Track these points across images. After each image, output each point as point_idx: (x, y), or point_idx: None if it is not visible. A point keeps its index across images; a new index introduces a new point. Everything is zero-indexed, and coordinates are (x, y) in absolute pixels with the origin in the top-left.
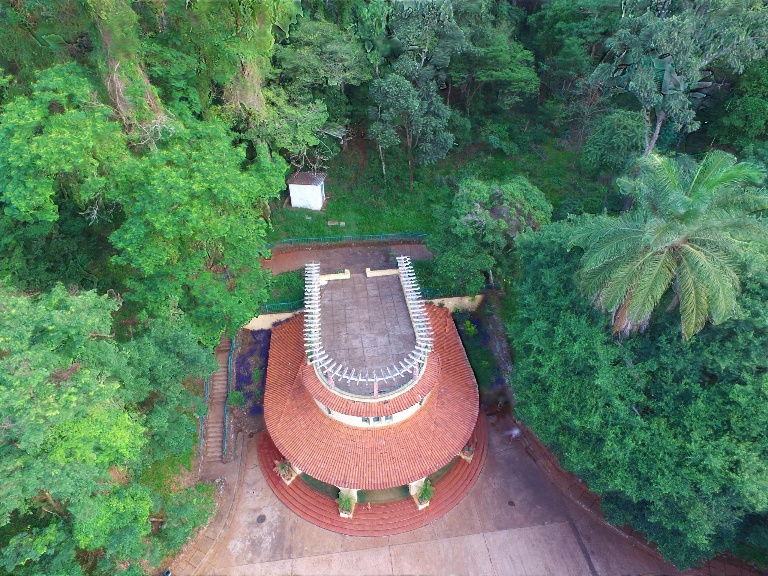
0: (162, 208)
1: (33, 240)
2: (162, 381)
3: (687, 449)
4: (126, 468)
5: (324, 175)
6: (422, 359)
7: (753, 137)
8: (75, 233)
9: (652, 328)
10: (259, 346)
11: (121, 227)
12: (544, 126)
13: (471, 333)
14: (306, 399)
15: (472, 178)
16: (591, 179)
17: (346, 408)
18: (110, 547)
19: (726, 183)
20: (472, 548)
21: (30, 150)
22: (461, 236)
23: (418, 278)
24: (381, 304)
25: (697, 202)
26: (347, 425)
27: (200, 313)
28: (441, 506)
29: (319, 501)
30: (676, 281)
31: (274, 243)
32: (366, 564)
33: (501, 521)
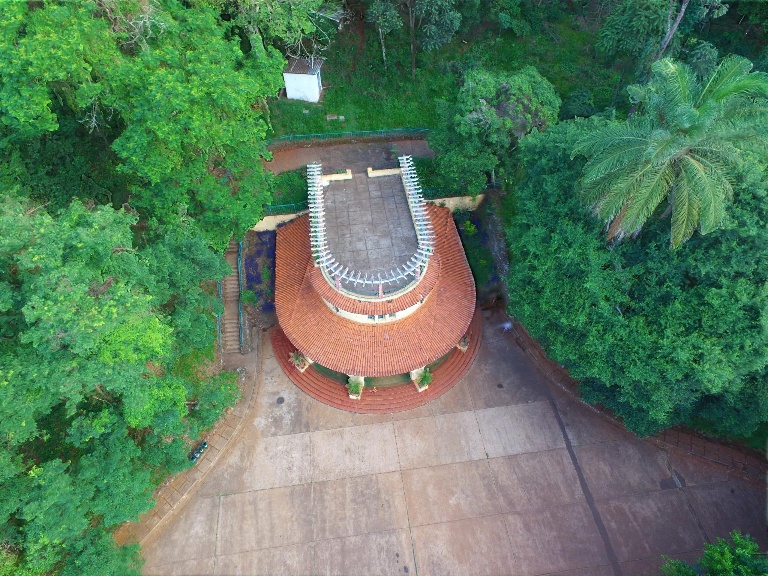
0: (162, 115)
1: (27, 142)
2: (180, 285)
3: (659, 344)
4: (159, 362)
5: (320, 62)
6: (424, 261)
7: None
8: (68, 133)
9: (644, 234)
10: (265, 247)
11: (122, 135)
12: None
13: (471, 233)
14: (315, 298)
15: (478, 64)
16: (605, 65)
17: (353, 307)
18: (156, 426)
19: (737, 93)
20: (464, 422)
21: (19, 55)
22: (465, 135)
23: (420, 177)
24: (383, 206)
25: (703, 117)
26: (354, 322)
27: (208, 218)
28: (438, 389)
29: (331, 386)
30: (672, 192)
31: (272, 140)
32: (373, 435)
33: (490, 400)
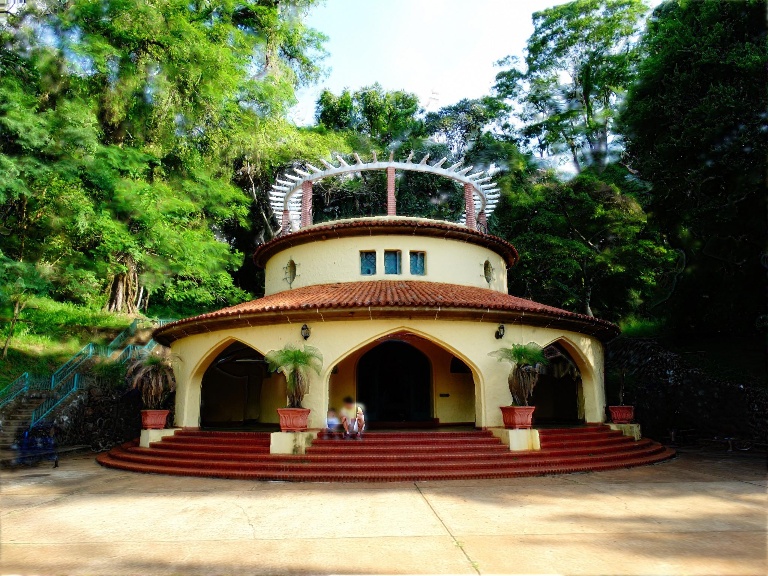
0: None
1: None
2: (0, 163)
3: None
4: None
5: None
6: None
7: None
8: None
9: None
10: None
11: None
12: None
13: None
14: None
15: None
16: None
17: None
18: None
19: None
20: None
21: None
22: (528, 209)
23: None
24: None
25: None
26: (326, 283)
27: (115, 203)
28: None
29: (219, 438)
30: None
31: None
32: None
33: None
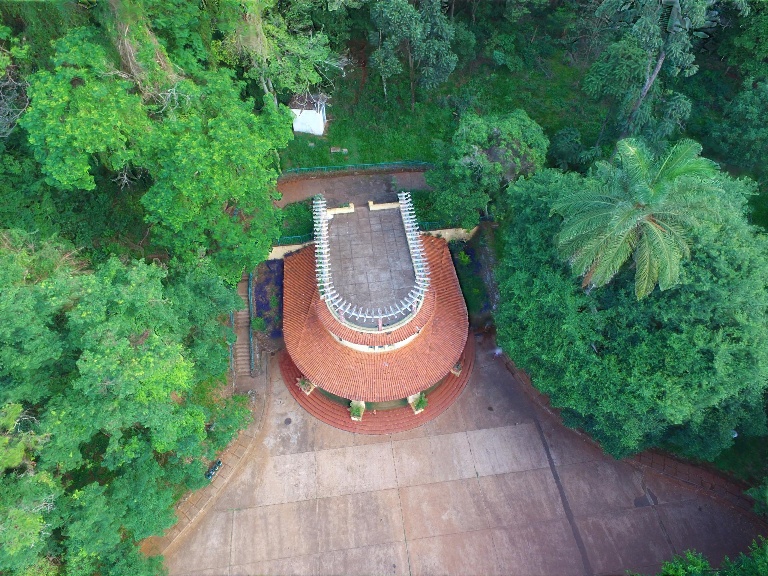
0: (187, 176)
1: None
2: (199, 319)
3: (627, 382)
4: (181, 391)
5: None
6: None
7: (761, 60)
8: (93, 172)
9: (617, 279)
10: (274, 275)
11: (150, 190)
12: (552, 35)
13: (465, 263)
14: (320, 327)
15: (474, 99)
16: (593, 100)
17: (355, 338)
18: (179, 450)
19: (687, 174)
20: (457, 443)
21: (65, 131)
22: (459, 177)
23: (418, 210)
24: (383, 239)
25: (656, 198)
26: (356, 350)
27: (222, 255)
28: (433, 411)
29: (334, 408)
30: (636, 252)
31: None
32: (373, 455)
33: (481, 422)
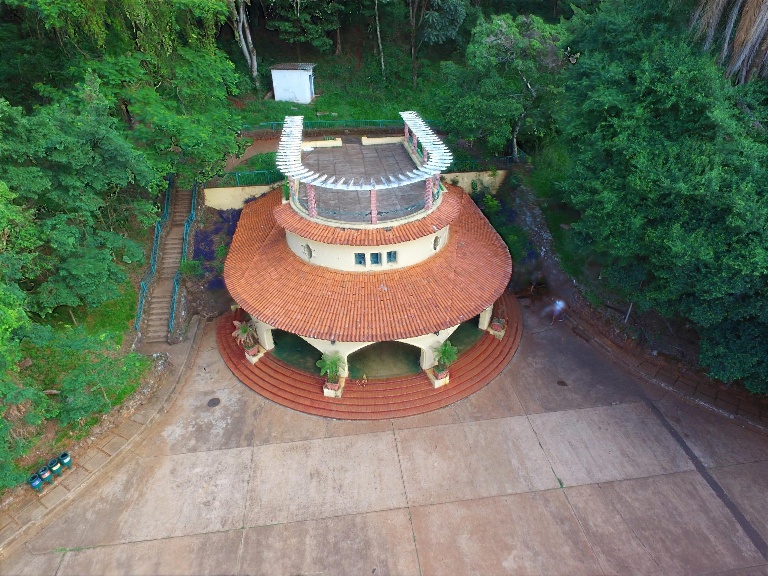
0: None
1: None
2: (70, 185)
3: None
4: None
5: (313, 64)
6: None
7: None
8: None
9: None
10: (227, 224)
11: None
12: None
13: (493, 208)
14: (280, 250)
15: None
16: None
17: (332, 237)
18: None
19: None
20: (512, 432)
21: None
22: (481, 69)
23: None
24: (380, 162)
25: None
26: (334, 270)
27: (139, 133)
28: (465, 385)
29: (295, 378)
30: None
31: (252, 127)
32: (360, 451)
33: (550, 402)
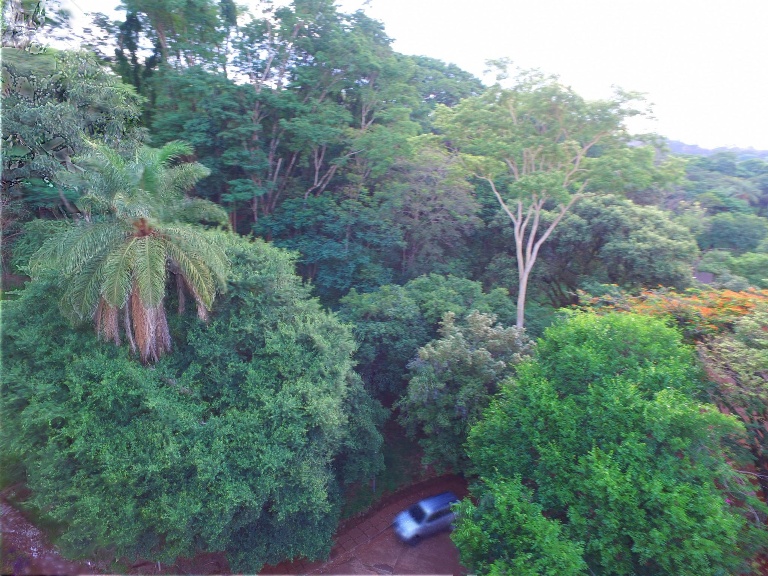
0: None
1: None
2: None
3: (266, 412)
4: None
5: None
6: None
7: None
8: None
9: None
10: None
11: None
12: None
13: None
14: None
15: None
16: None
17: None
18: None
19: (164, 162)
20: None
21: None
22: None
23: None
24: None
25: None
26: None
27: None
28: None
29: None
30: (171, 260)
31: None
32: None
33: None
